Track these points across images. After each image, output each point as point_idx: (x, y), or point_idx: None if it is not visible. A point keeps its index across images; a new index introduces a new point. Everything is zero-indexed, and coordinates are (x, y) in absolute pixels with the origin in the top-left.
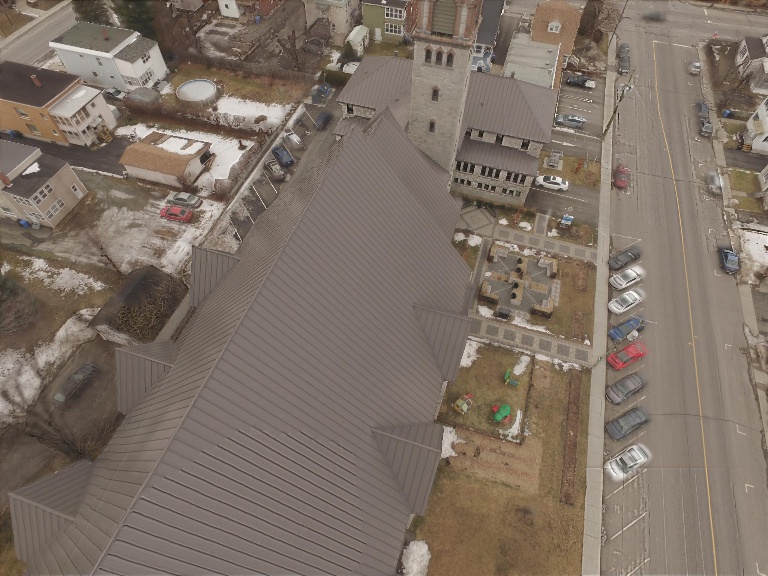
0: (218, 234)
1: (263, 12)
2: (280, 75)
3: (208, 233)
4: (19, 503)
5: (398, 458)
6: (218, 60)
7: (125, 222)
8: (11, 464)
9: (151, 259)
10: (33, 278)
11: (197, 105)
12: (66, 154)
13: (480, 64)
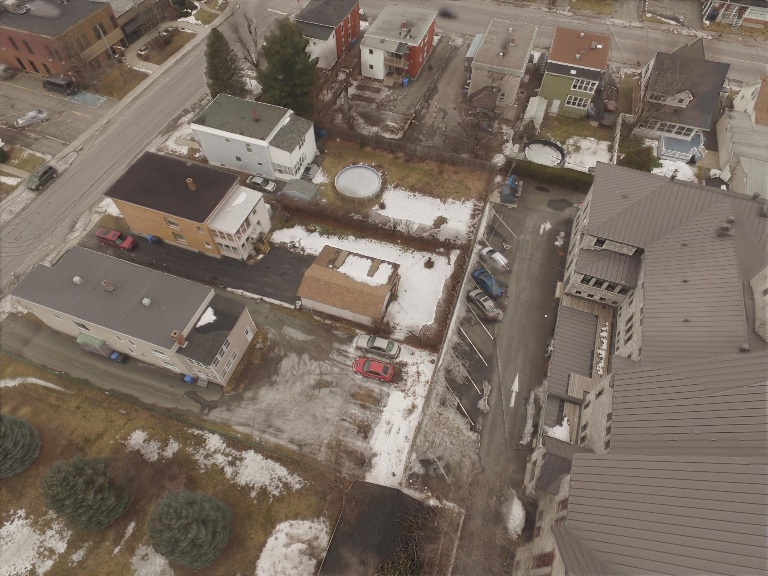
0: (437, 406)
1: (411, 73)
2: (451, 160)
3: (425, 405)
4: None
5: None
6: (375, 139)
7: (311, 378)
8: None
9: (356, 441)
10: (210, 465)
11: (361, 201)
12: (218, 269)
13: (692, 151)
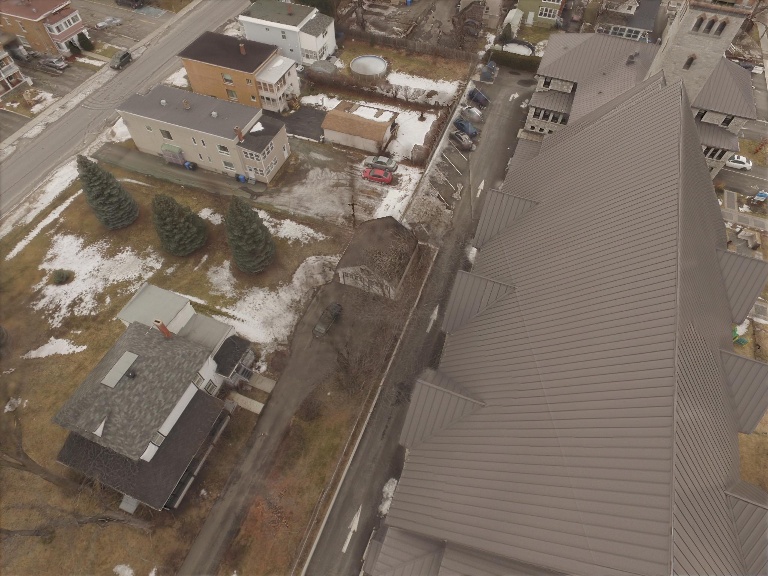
0: (422, 195)
1: None
2: (443, 54)
3: (414, 194)
4: (426, 389)
5: (741, 378)
6: (383, 38)
7: (331, 181)
8: (287, 384)
9: (364, 215)
10: None
11: (370, 79)
12: None
13: None
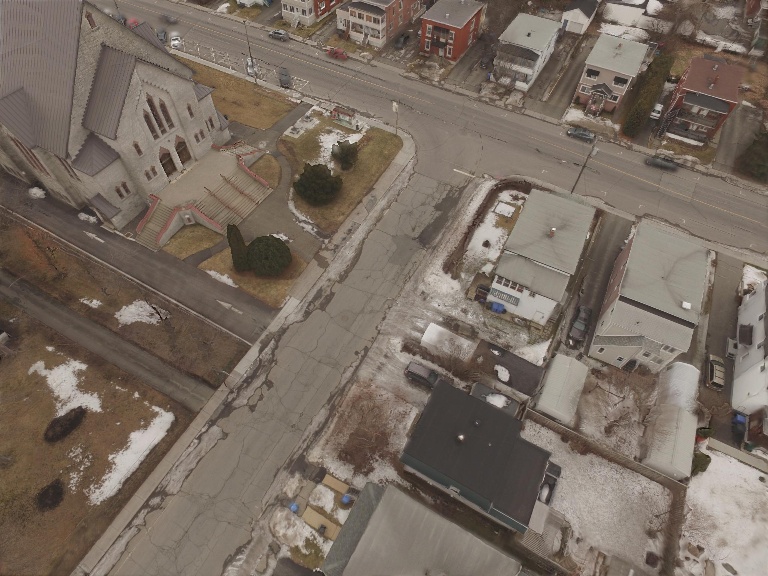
0: None
1: None
2: None
3: None
4: None
5: None
6: None
7: None
8: None
9: None
10: None
11: None
12: None
13: None
